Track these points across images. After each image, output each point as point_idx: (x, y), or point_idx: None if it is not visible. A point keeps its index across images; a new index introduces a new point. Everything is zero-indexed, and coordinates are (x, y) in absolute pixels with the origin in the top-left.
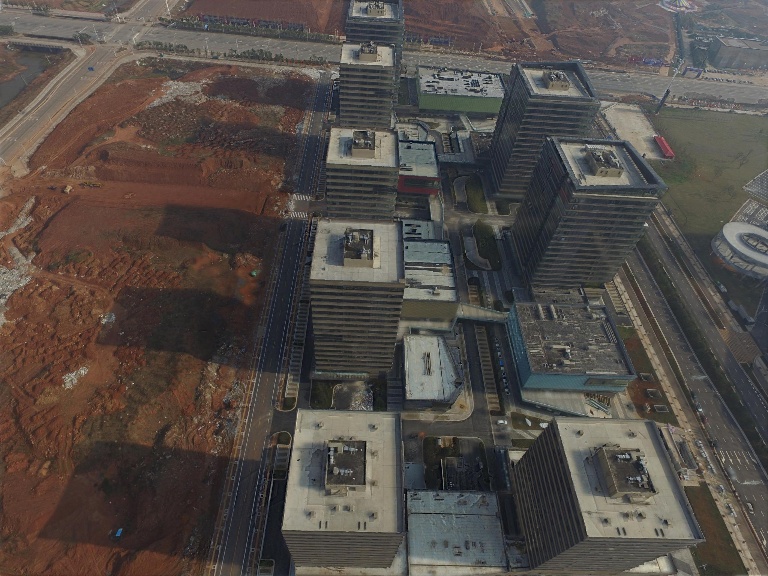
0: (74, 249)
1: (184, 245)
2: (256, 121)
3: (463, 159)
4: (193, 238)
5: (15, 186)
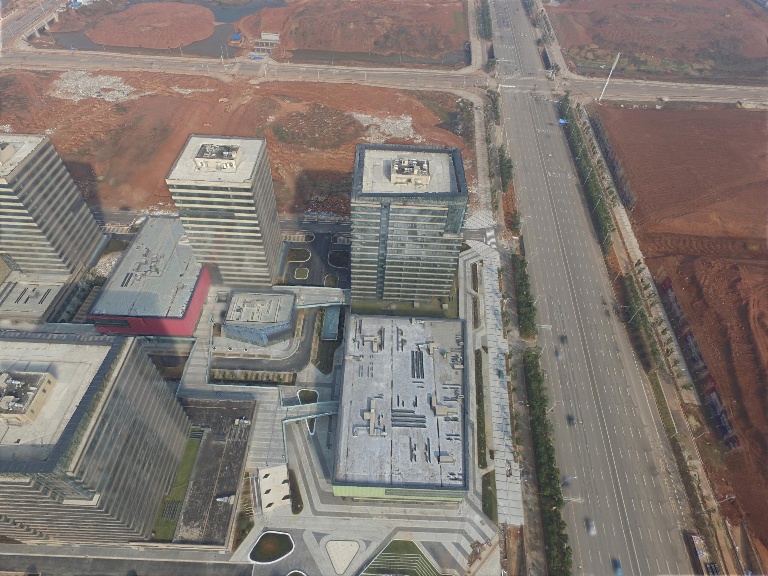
0: (131, 109)
1: (114, 152)
2: (325, 177)
3: (192, 385)
4: (117, 154)
5: (237, 83)
